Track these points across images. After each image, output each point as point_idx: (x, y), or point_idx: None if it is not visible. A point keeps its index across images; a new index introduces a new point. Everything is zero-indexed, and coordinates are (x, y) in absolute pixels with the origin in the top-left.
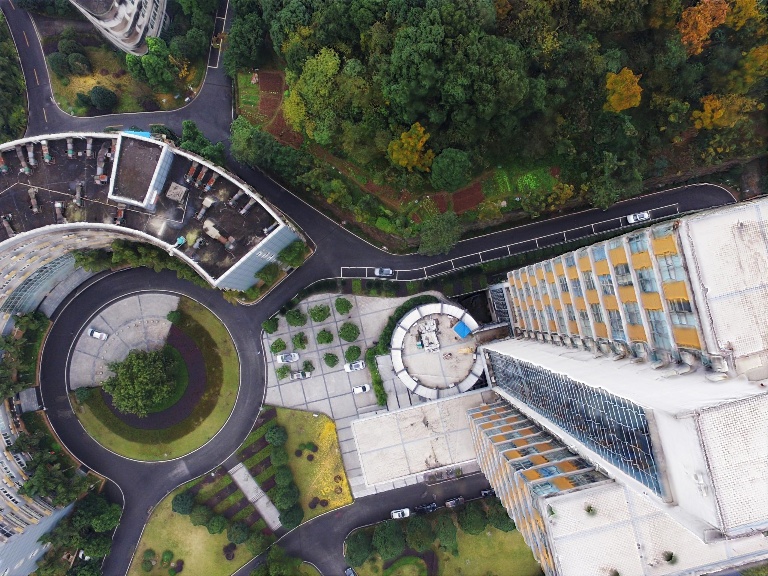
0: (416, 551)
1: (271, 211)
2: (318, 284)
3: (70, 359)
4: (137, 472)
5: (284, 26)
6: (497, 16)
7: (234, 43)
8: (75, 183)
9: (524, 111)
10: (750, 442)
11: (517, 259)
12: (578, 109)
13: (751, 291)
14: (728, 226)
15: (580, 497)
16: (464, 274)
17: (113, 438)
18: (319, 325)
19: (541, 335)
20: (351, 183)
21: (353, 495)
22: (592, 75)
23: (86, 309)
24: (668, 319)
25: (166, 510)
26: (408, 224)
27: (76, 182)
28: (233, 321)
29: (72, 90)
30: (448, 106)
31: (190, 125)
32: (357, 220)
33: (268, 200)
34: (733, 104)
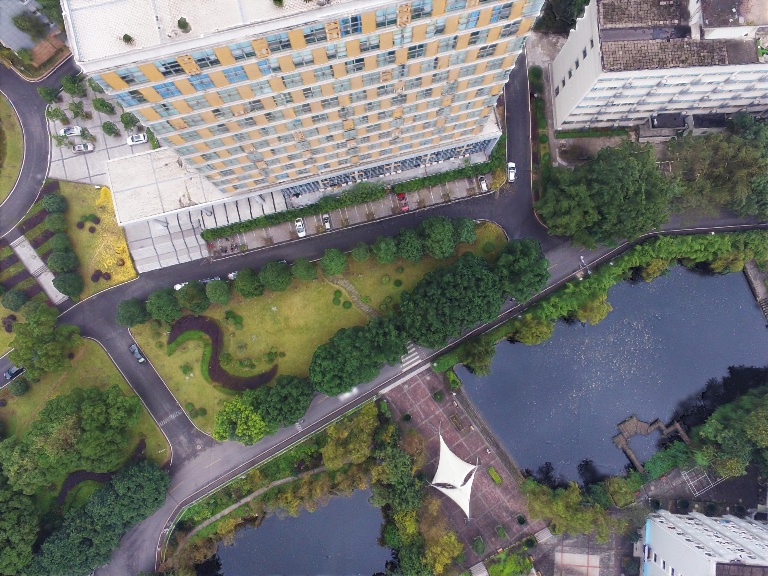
0: (200, 325)
1: None
2: None
3: None
4: None
5: None
6: None
7: None
8: None
9: None
10: None
11: None
12: None
13: None
14: None
15: None
16: None
17: None
18: None
19: None
20: None
21: (137, 269)
22: None
23: None
24: None
25: None
26: None
27: None
28: (18, 97)
29: None
30: None
31: None
32: None
33: None
34: None
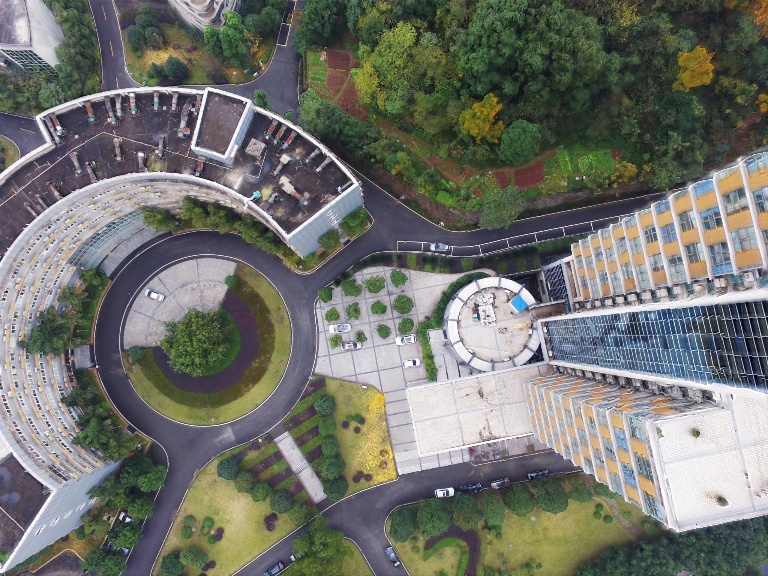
0: (459, 533)
1: (346, 170)
2: (374, 256)
3: (125, 318)
4: (183, 435)
5: (363, 1)
6: None
7: (308, 20)
8: (158, 135)
9: (596, 86)
10: None
11: (572, 240)
12: (643, 91)
13: None
14: None
15: (688, 423)
16: (519, 253)
17: (162, 400)
18: (372, 297)
19: (611, 300)
20: (415, 156)
21: (398, 471)
22: (663, 54)
23: (145, 270)
24: None
25: (210, 476)
26: (469, 198)
27: (159, 134)
28: (288, 289)
29: (145, 62)
30: (523, 77)
31: (261, 94)
32: (420, 192)
33: None
34: None
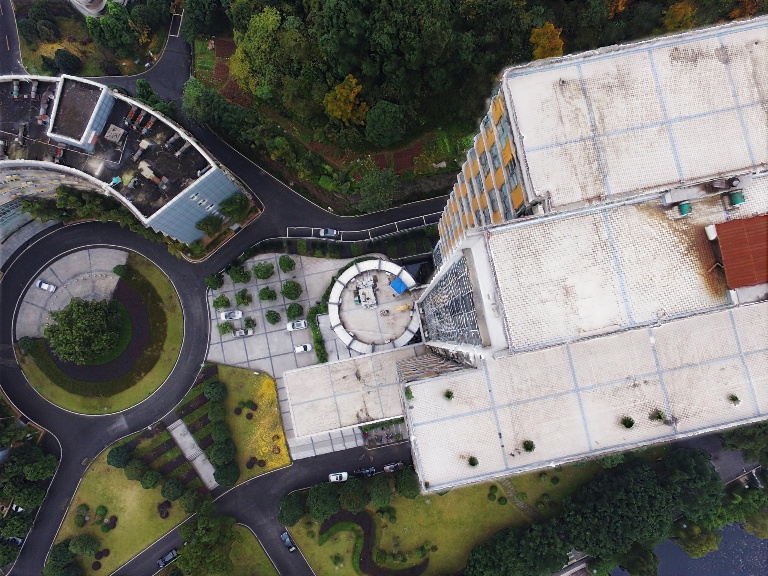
0: (353, 517)
1: (204, 154)
2: (264, 243)
3: (18, 310)
4: (76, 425)
5: None
6: None
7: (190, 8)
8: (19, 123)
9: (452, 64)
10: (544, 265)
11: None
12: None
13: (571, 145)
14: (550, 83)
15: (442, 384)
16: (407, 236)
17: (55, 390)
18: (264, 284)
19: None
20: (295, 141)
21: (291, 456)
22: (519, 32)
23: (37, 261)
24: (508, 186)
25: (103, 464)
26: None
27: (20, 122)
28: (180, 278)
29: None
30: (378, 58)
31: (144, 84)
32: (299, 176)
33: (220, 161)
34: None
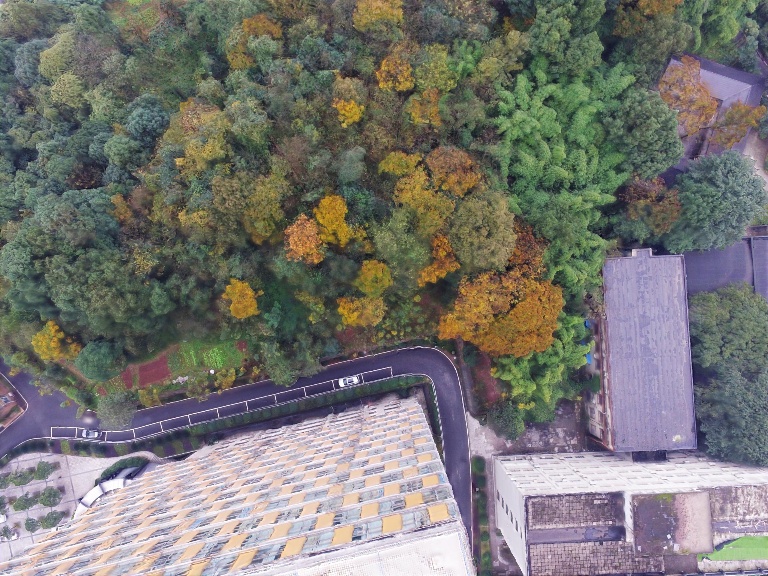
0: None
1: None
2: (24, 445)
3: None
4: None
5: None
6: (121, 221)
7: None
8: None
9: (153, 313)
10: None
11: (225, 423)
12: None
13: None
14: None
15: None
16: (171, 437)
17: None
18: (29, 485)
19: None
20: (39, 354)
21: None
22: None
23: None
24: None
25: None
26: (93, 397)
27: None
28: None
29: None
30: None
31: None
32: (40, 393)
33: None
34: (366, 308)
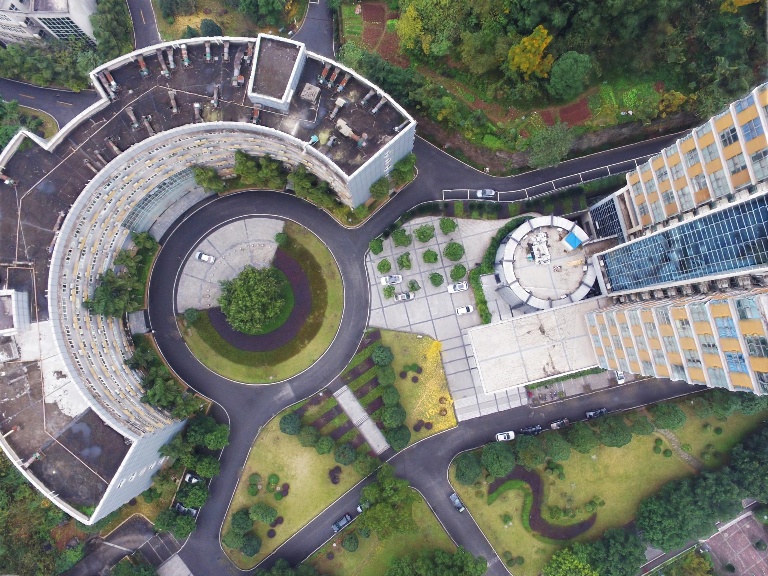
0: (522, 475)
1: (402, 109)
2: (421, 206)
3: (178, 283)
4: (243, 395)
5: None
6: None
7: None
8: (212, 85)
9: (645, 11)
10: None
11: (617, 178)
12: (687, 18)
13: None
14: None
15: None
16: (566, 194)
17: (219, 361)
18: (422, 247)
19: (676, 219)
20: (459, 101)
21: (457, 418)
22: None
23: (193, 234)
24: None
25: (272, 433)
26: (516, 139)
27: (213, 85)
28: (337, 245)
29: (177, 28)
30: (572, 6)
31: None
32: (467, 135)
33: None
34: None
